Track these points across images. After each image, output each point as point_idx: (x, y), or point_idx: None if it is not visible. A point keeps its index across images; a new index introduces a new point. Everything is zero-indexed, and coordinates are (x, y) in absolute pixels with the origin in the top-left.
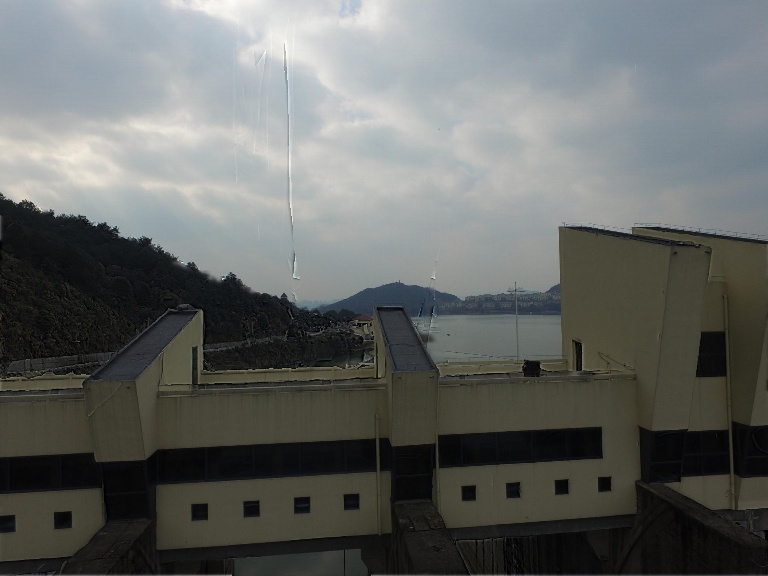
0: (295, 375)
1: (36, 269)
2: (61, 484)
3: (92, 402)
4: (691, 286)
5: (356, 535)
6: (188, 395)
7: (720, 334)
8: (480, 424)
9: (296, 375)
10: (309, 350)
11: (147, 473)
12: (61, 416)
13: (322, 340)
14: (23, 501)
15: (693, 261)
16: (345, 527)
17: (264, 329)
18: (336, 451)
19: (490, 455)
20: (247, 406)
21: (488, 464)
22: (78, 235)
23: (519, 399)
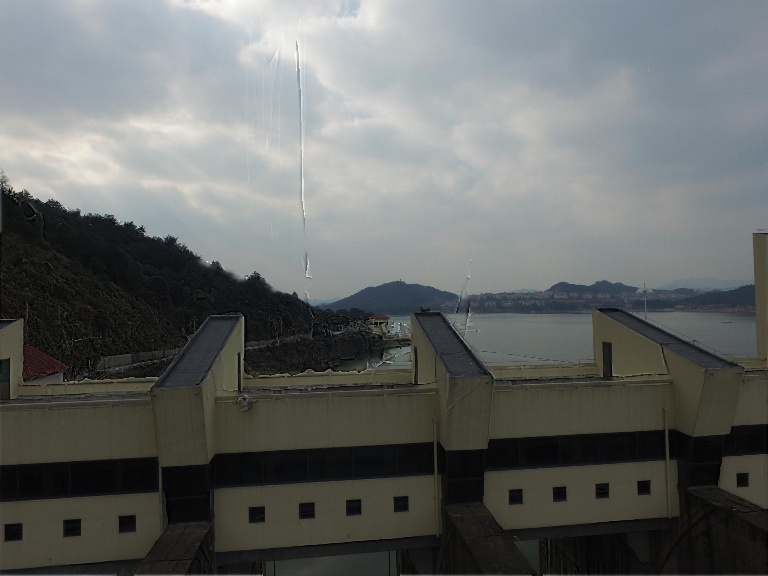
0: (527, 372)
1: (85, 268)
2: (398, 471)
3: (454, 396)
4: None
5: (648, 518)
6: (503, 390)
7: None
8: (751, 417)
9: (527, 372)
10: (334, 349)
11: (484, 461)
12: (397, 409)
13: (345, 339)
14: (366, 487)
15: None
16: (639, 511)
17: (288, 328)
18: (625, 441)
19: (758, 445)
20: (554, 400)
21: (758, 453)
22: (107, 234)
23: None
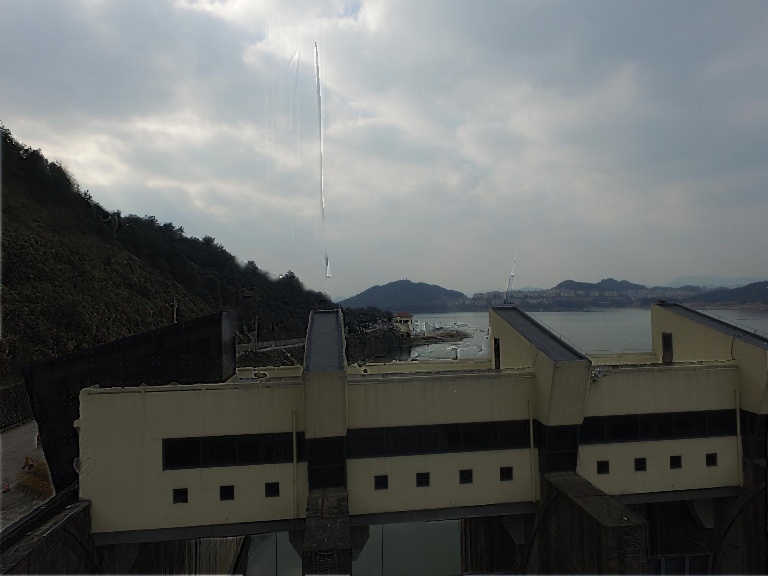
0: None
1: (152, 268)
2: (708, 433)
3: None
4: None
5: None
6: None
7: None
8: None
9: None
10: (368, 346)
11: None
12: (706, 381)
13: (377, 336)
14: (684, 445)
15: None
16: None
17: None
18: None
19: None
20: None
21: None
22: None
23: None
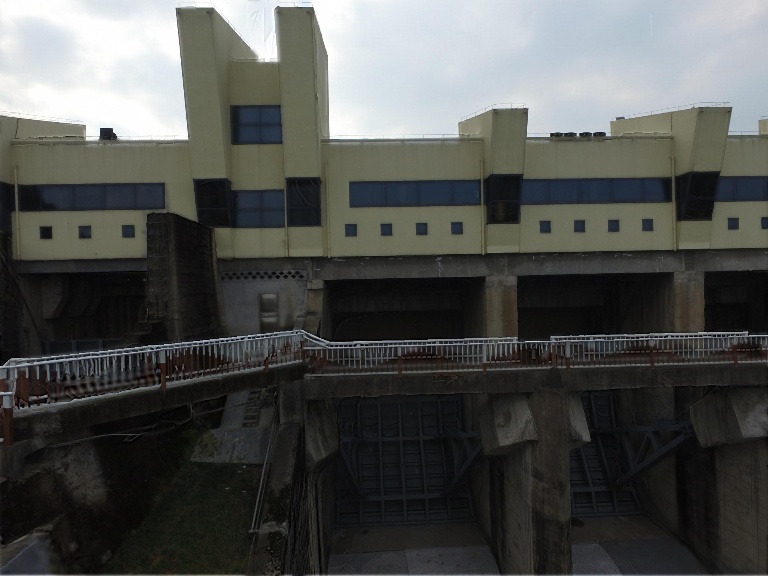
0: None
1: None
2: None
3: None
4: (202, 45)
5: None
6: None
7: (279, 107)
8: (56, 177)
9: None
10: None
11: None
12: None
13: None
14: None
15: (198, 21)
16: None
17: None
18: None
19: (68, 204)
20: None
21: (64, 210)
22: None
23: (91, 158)
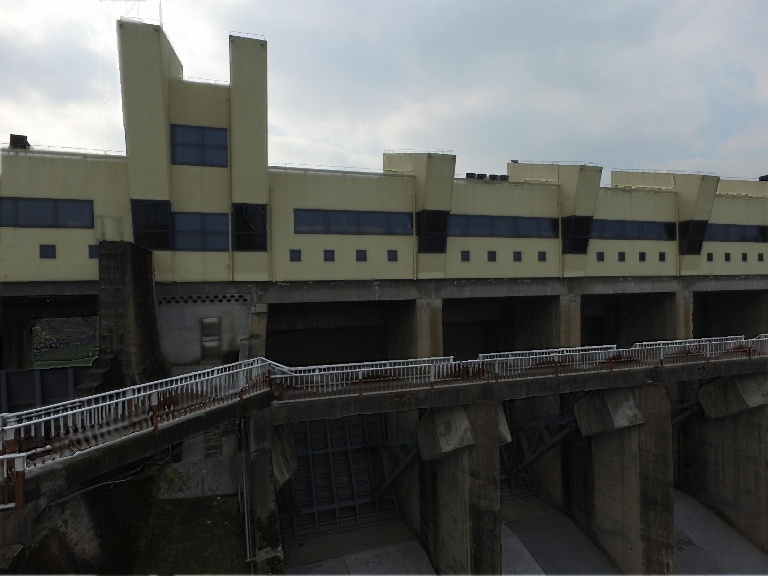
0: None
1: None
2: None
3: None
4: (146, 62)
5: None
6: None
7: (224, 131)
8: None
9: None
10: None
11: None
12: None
13: None
14: None
15: (144, 37)
16: None
17: None
18: None
19: None
20: None
21: None
22: None
23: None
